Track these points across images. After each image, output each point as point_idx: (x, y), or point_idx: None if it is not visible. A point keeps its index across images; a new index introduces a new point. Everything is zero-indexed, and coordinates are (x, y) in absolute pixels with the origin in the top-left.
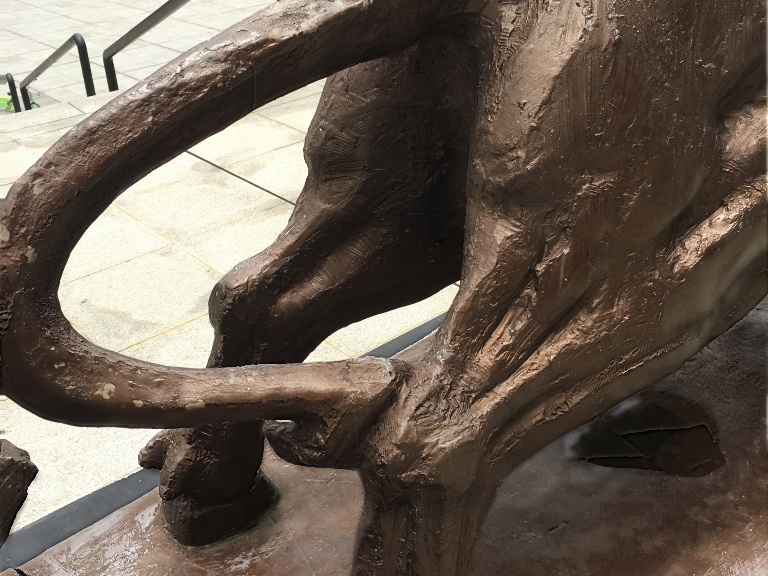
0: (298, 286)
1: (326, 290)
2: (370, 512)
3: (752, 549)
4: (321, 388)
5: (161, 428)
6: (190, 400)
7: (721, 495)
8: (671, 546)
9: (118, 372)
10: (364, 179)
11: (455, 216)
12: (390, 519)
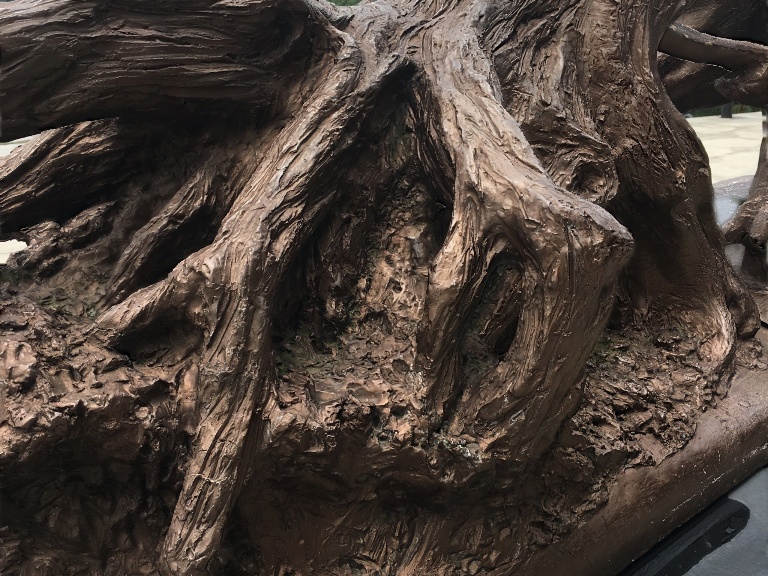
0: (673, 72)
1: (689, 75)
2: None
3: None
4: (760, 48)
5: (687, 59)
6: (706, 41)
7: None
8: None
9: (675, 23)
10: (716, 8)
11: (765, 31)
12: None
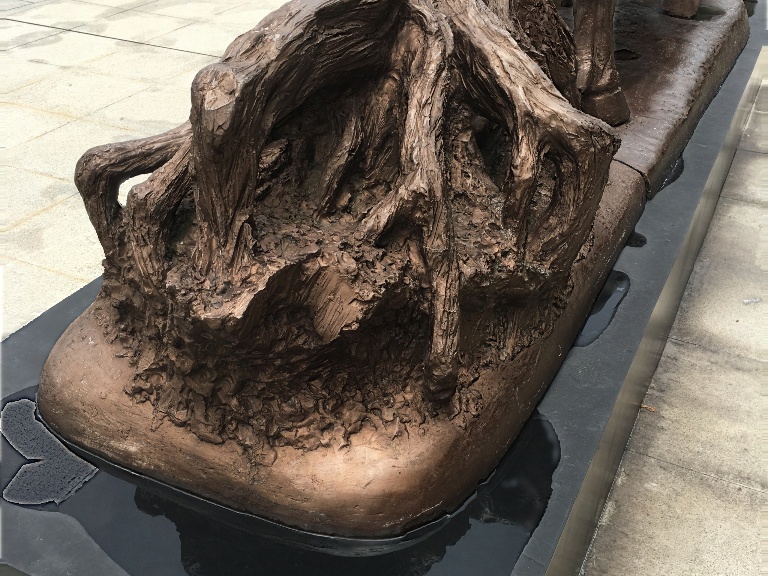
0: None
1: None
2: (586, 6)
3: (670, 71)
4: None
5: None
6: None
7: (648, 62)
8: (641, 74)
9: None
10: None
11: None
12: (595, 6)
